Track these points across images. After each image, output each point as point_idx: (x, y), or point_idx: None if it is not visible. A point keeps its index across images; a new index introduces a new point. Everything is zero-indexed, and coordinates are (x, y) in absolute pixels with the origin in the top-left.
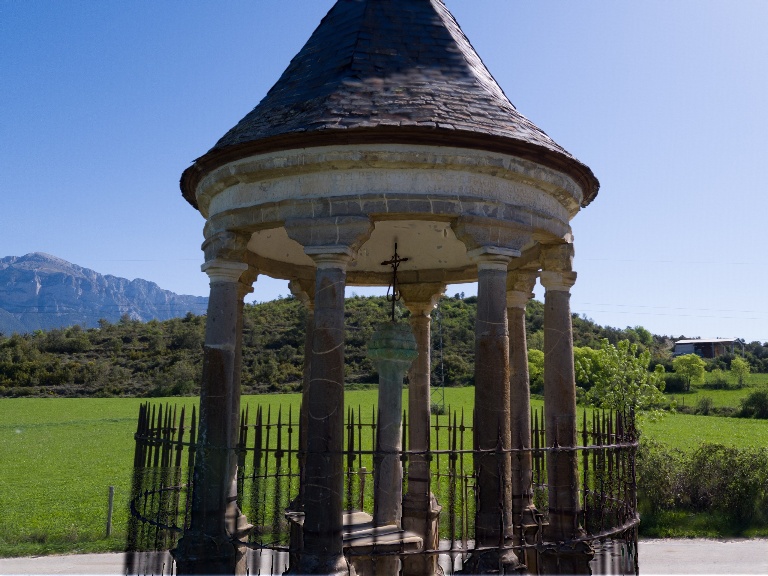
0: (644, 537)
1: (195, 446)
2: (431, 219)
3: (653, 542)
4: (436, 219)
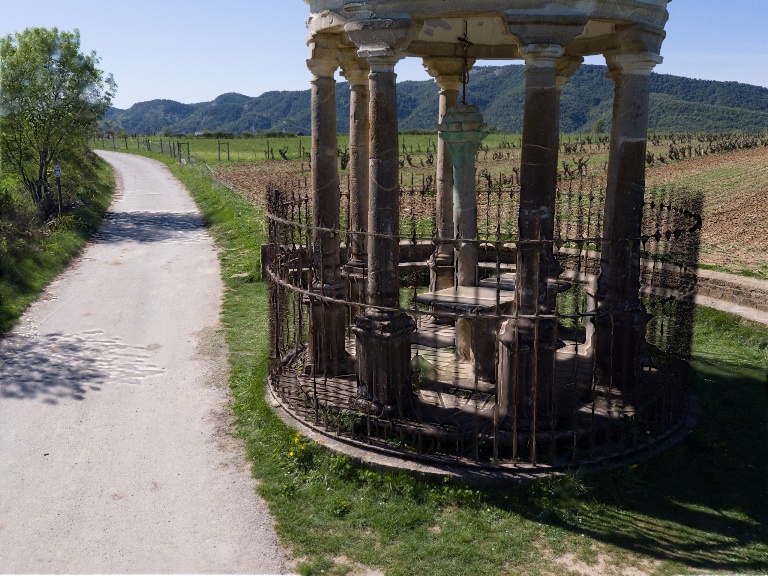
0: (14, 320)
1: None
2: None
3: (37, 319)
4: (584, 54)
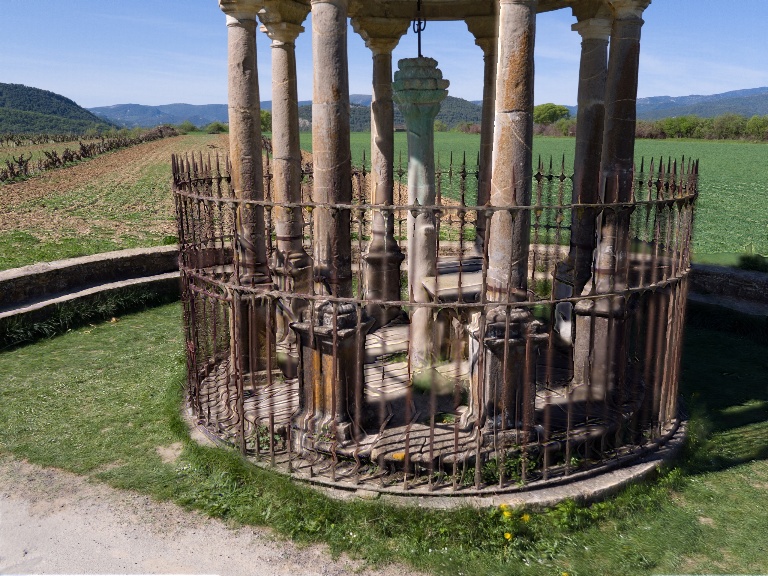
0: None
1: (572, 177)
2: (428, 18)
3: None
4: None
